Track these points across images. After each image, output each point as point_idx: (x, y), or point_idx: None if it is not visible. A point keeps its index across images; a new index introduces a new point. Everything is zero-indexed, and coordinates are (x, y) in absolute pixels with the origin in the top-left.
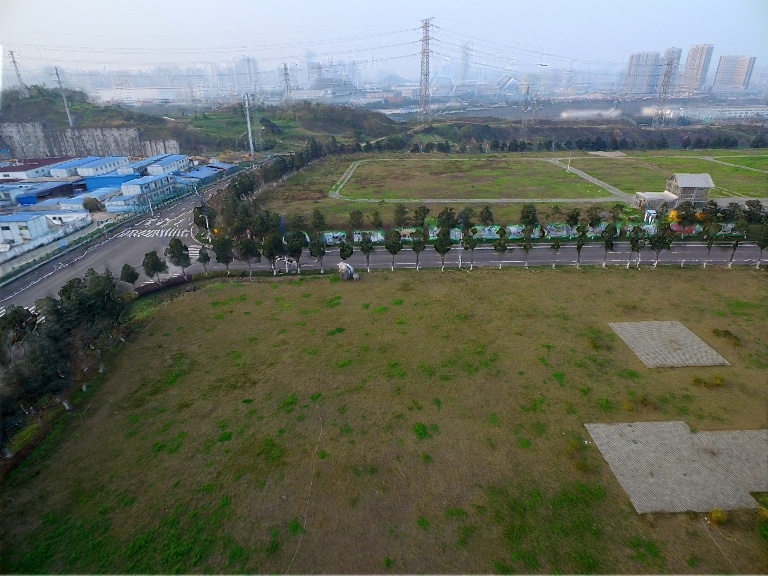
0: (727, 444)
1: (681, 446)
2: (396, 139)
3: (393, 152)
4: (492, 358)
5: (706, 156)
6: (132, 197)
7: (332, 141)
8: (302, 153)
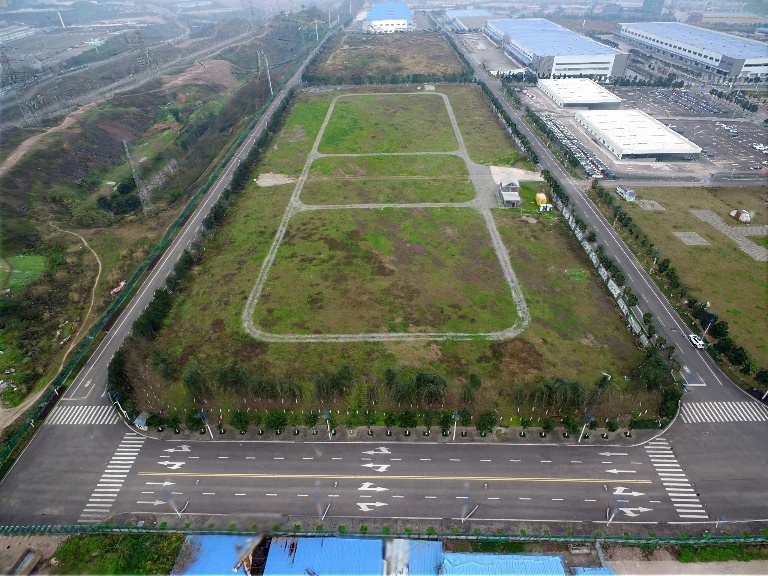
0: (742, 243)
1: (750, 249)
2: (13, 305)
3: (178, 306)
4: (739, 271)
5: (310, 153)
6: (589, 573)
7: (159, 358)
8: (347, 367)
